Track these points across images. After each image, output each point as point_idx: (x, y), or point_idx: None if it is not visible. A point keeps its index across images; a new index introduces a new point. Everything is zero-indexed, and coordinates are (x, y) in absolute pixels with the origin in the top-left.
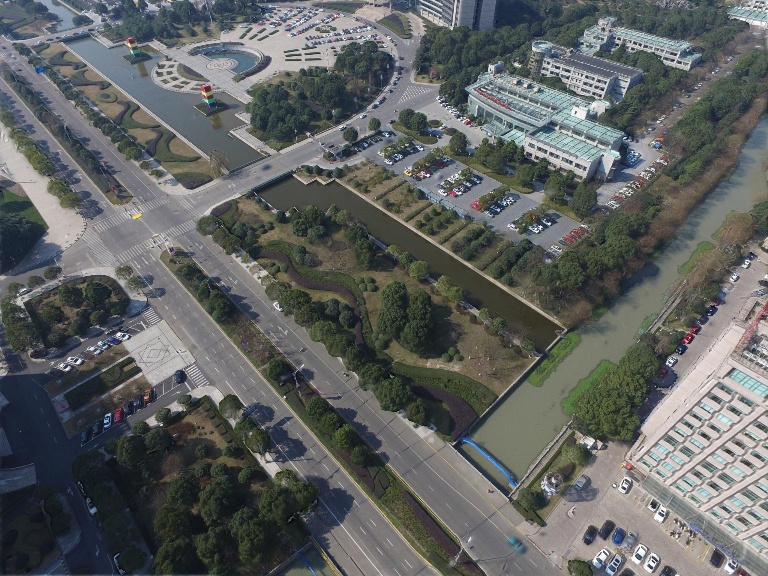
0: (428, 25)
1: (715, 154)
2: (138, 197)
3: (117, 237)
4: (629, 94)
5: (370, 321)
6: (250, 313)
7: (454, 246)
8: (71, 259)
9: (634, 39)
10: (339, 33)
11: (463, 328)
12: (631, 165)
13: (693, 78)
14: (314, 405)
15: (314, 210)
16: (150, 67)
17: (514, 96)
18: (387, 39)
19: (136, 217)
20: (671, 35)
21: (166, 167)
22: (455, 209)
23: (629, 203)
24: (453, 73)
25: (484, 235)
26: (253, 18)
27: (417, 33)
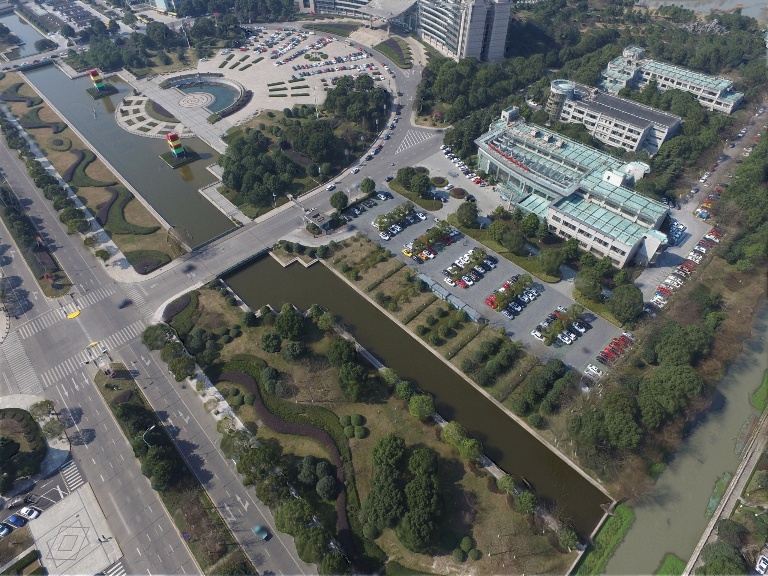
0: (430, 52)
1: None
2: (78, 285)
3: (45, 346)
4: (666, 147)
5: (357, 488)
6: (201, 472)
7: (465, 367)
8: None
9: (665, 75)
10: (331, 62)
11: (479, 500)
12: (675, 242)
13: (738, 125)
14: None
15: (290, 315)
16: (116, 102)
17: (532, 150)
18: (384, 69)
19: (72, 316)
20: (703, 66)
21: (117, 242)
22: (466, 309)
23: (680, 300)
24: (459, 115)
25: (503, 351)
26: (235, 43)
27: (418, 62)
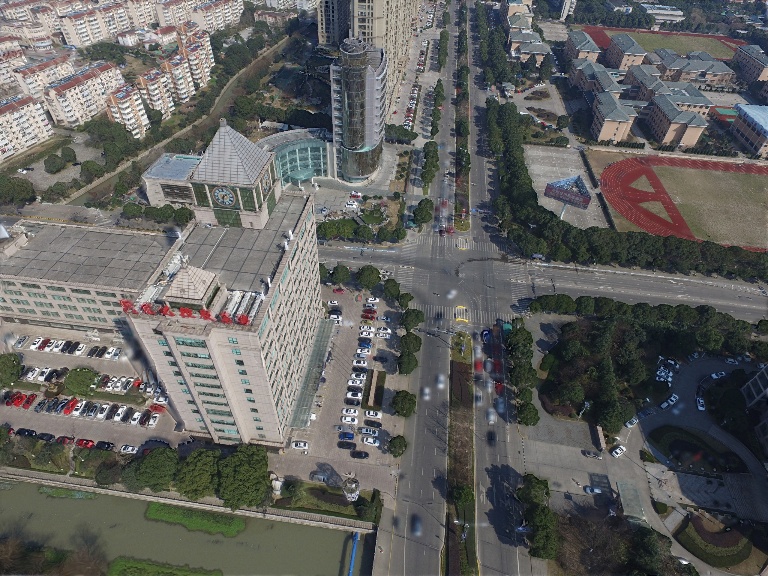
0: None
1: None
2: None
3: None
4: None
5: None
6: None
7: None
8: None
9: None
10: None
11: None
12: None
13: None
14: None
15: None
16: None
17: None
18: None
19: None
20: None
21: None
22: None
23: None
24: None
25: None
26: None
27: None
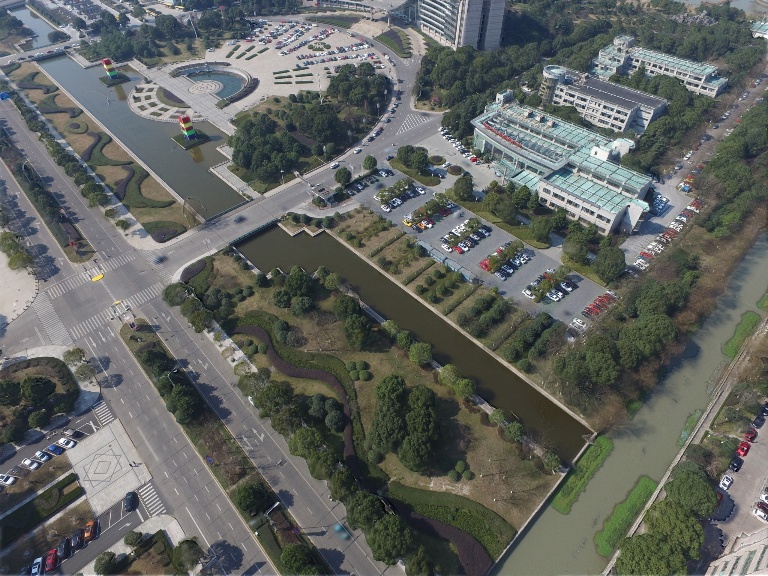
0: (429, 43)
1: (755, 203)
2: (101, 252)
3: (72, 305)
4: (652, 127)
5: (362, 422)
6: (220, 410)
7: (461, 320)
8: (16, 334)
9: (654, 61)
10: (333, 51)
11: (473, 432)
12: (658, 213)
13: (721, 107)
14: (290, 557)
15: (299, 275)
16: (128, 90)
17: (525, 130)
18: (385, 58)
19: (96, 279)
20: (691, 55)
21: (135, 214)
22: (461, 271)
23: (660, 263)
24: (457, 100)
25: (495, 306)
26: (241, 34)
27: (417, 51)
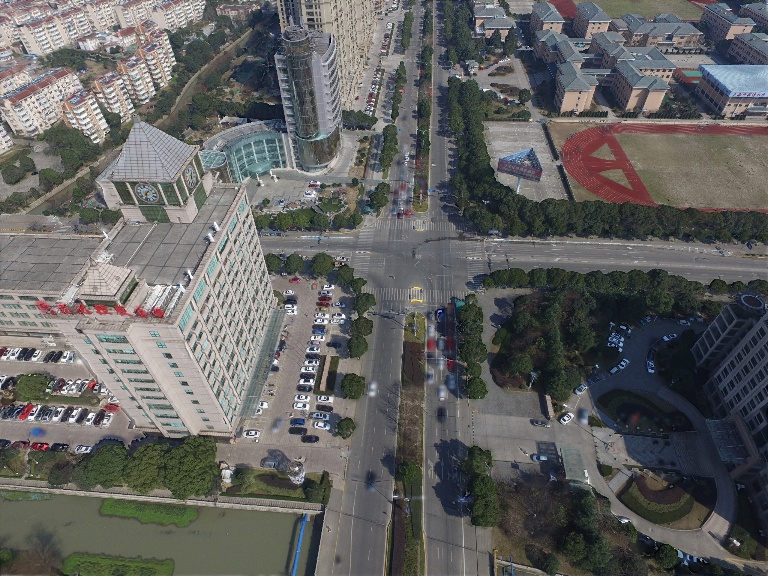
0: None
1: None
2: None
3: None
4: None
5: None
6: None
7: None
8: None
9: None
10: None
11: None
12: None
13: None
14: None
15: None
16: None
17: None
18: None
19: None
20: None
21: None
22: None
23: None
24: None
25: None
26: None
27: None
